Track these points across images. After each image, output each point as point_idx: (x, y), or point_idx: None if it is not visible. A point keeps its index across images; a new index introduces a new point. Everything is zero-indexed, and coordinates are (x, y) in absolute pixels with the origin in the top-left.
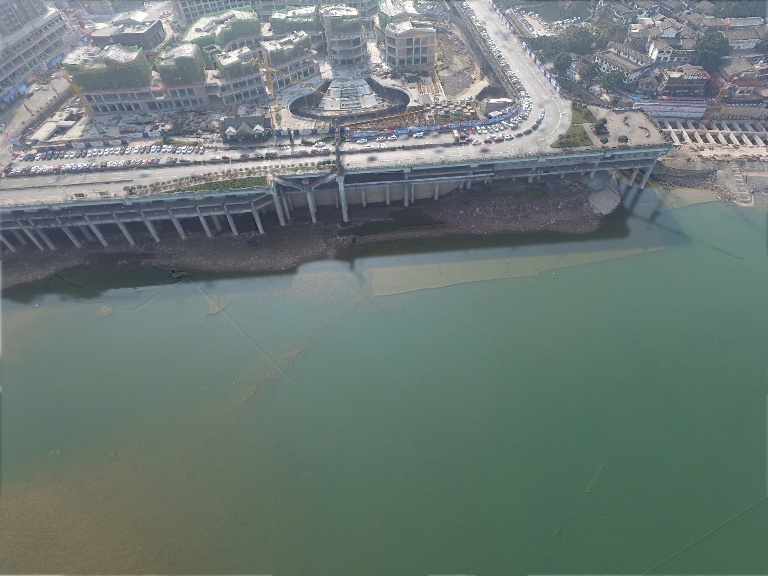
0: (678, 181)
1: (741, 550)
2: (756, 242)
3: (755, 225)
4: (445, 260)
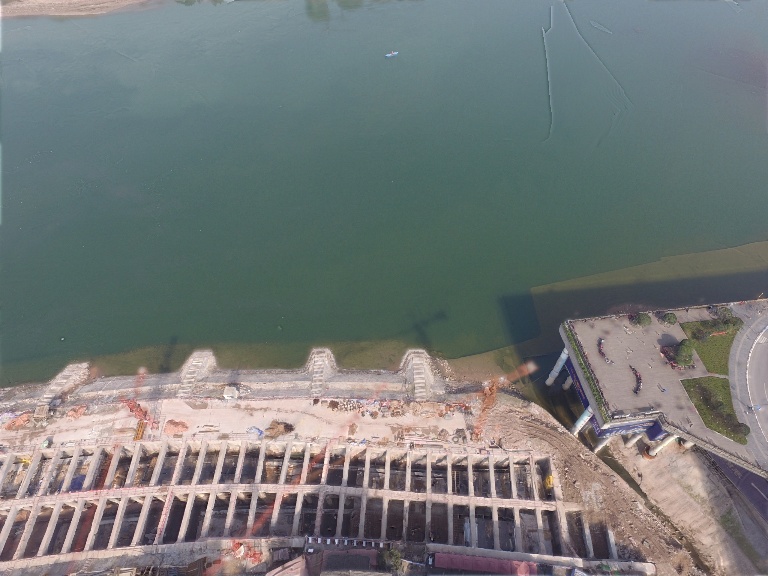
0: (497, 390)
1: (523, 131)
2: (433, 295)
3: (422, 318)
4: (764, 270)
